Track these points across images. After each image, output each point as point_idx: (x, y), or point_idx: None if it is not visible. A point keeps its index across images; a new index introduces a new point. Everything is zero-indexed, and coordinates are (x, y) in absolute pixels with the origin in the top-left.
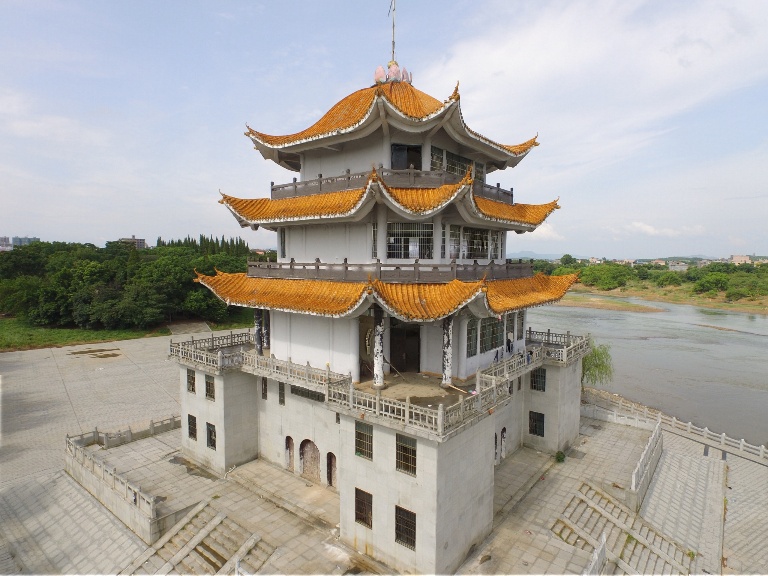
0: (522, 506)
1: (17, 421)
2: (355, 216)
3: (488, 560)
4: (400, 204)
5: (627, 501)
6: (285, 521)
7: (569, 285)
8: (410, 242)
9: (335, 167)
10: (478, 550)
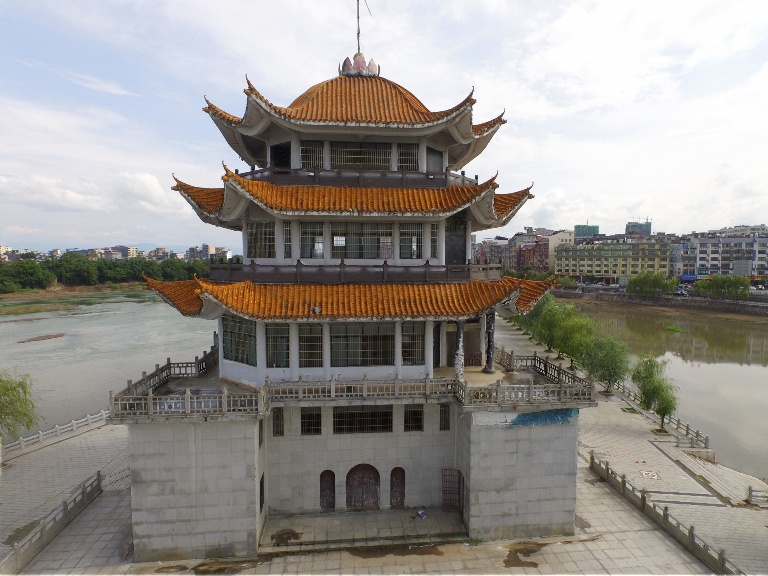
0: None
1: None
2: None
3: None
4: None
5: None
6: None
7: None
8: None
9: None
10: None
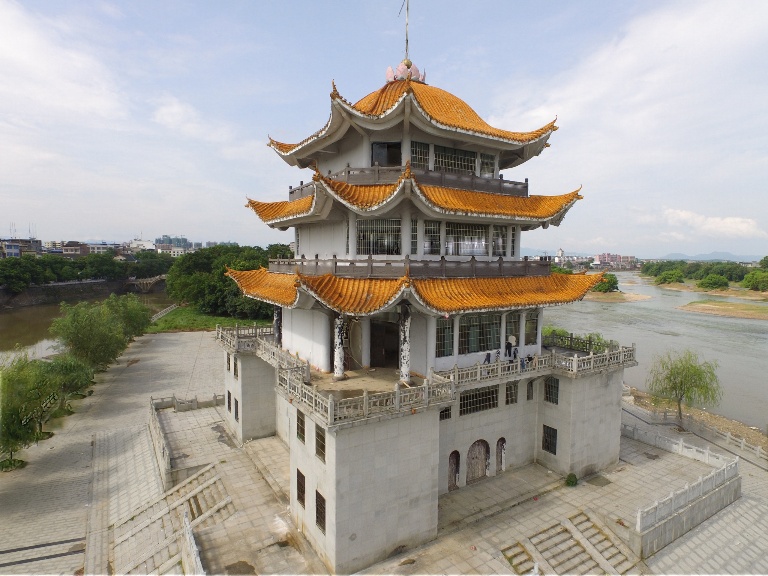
0: (488, 521)
1: (150, 385)
2: (320, 214)
3: (409, 564)
4: (346, 201)
5: (630, 543)
6: (260, 491)
7: (590, 286)
8: (378, 238)
9: (335, 169)
10: (407, 552)
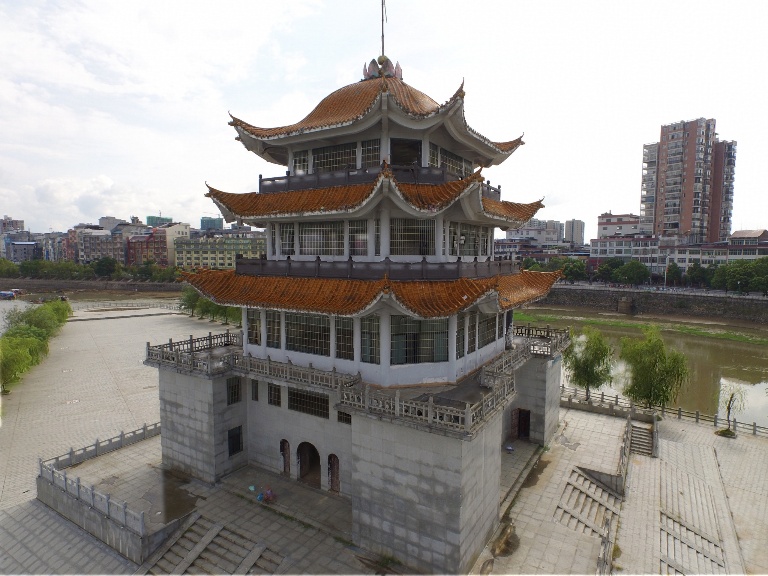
0: None
1: None
2: None
3: None
4: None
5: None
6: None
7: None
8: None
9: None
10: None
